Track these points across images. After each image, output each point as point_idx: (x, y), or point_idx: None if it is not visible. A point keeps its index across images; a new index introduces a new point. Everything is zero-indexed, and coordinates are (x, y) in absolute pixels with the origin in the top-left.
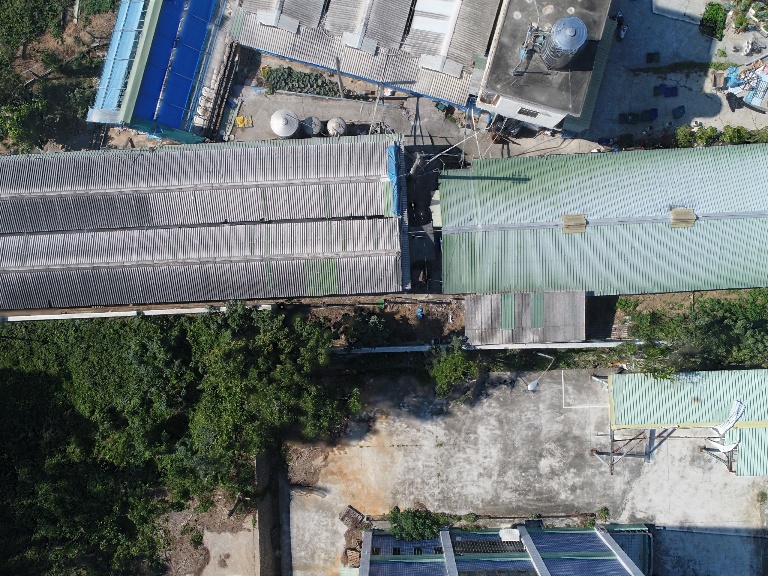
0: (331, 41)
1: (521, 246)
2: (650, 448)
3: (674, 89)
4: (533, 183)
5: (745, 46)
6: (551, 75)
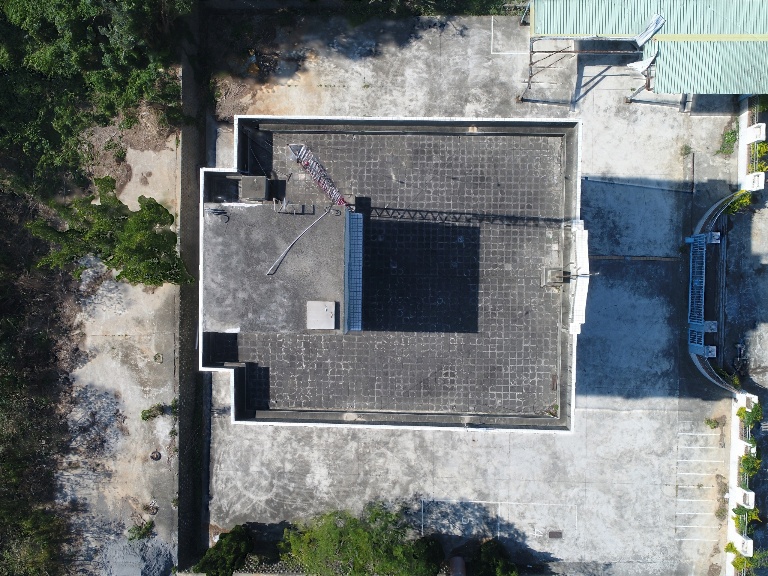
0: None
1: None
2: (576, 97)
3: None
4: None
5: None
6: None
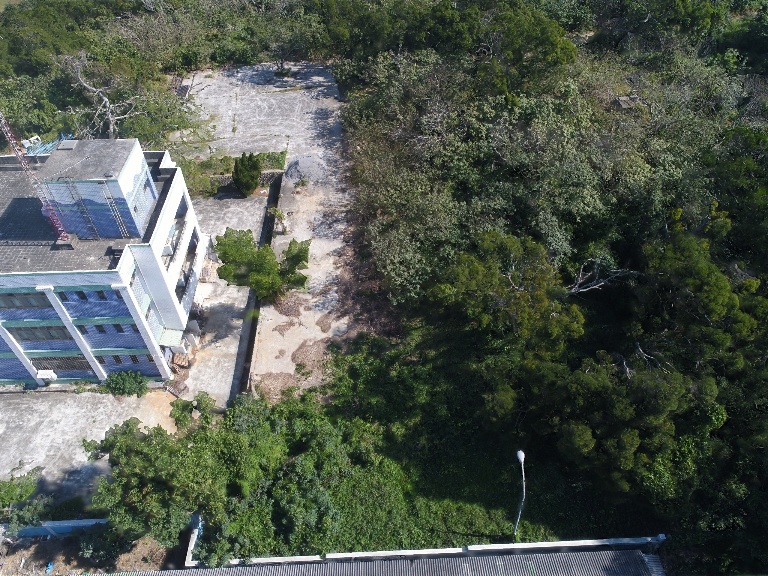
0: None
1: None
2: None
3: None
4: None
5: None
6: None
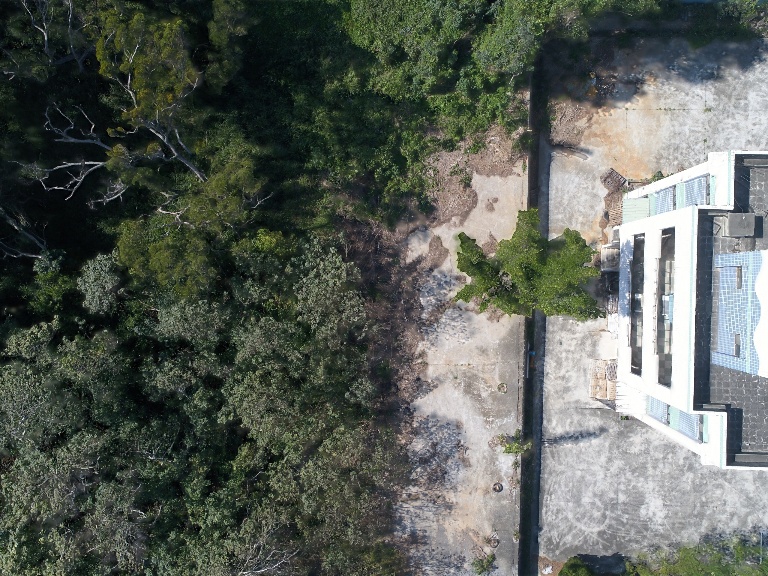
0: None
1: None
2: None
3: None
4: None
5: None
6: None
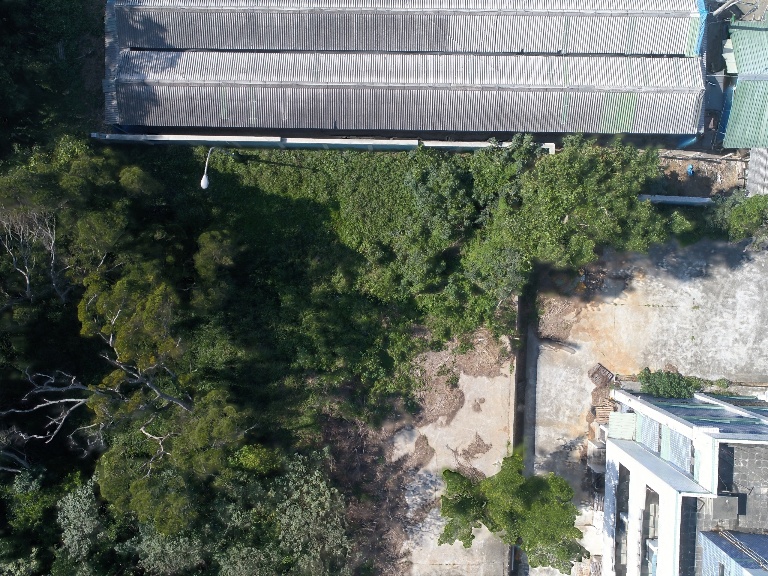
0: None
1: None
2: None
3: None
4: None
5: None
6: None
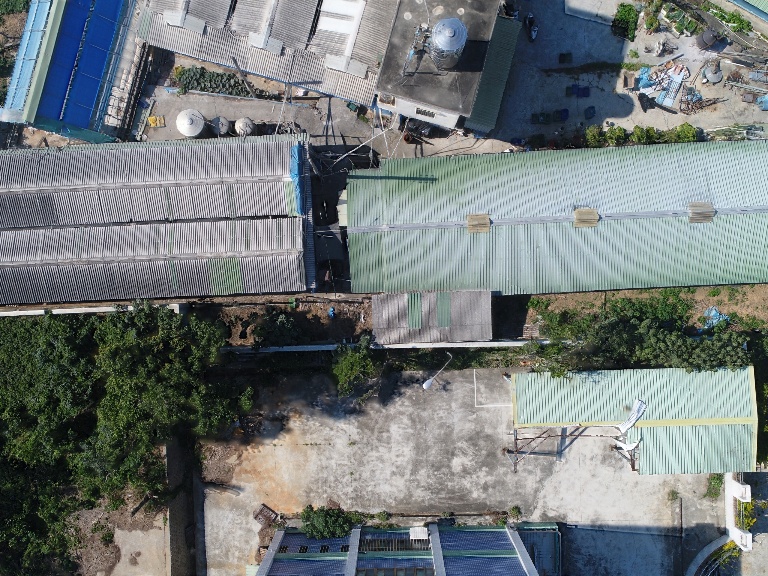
0: (238, 41)
1: (427, 246)
2: (561, 447)
3: (586, 89)
4: (440, 183)
5: (656, 47)
6: (441, 75)
